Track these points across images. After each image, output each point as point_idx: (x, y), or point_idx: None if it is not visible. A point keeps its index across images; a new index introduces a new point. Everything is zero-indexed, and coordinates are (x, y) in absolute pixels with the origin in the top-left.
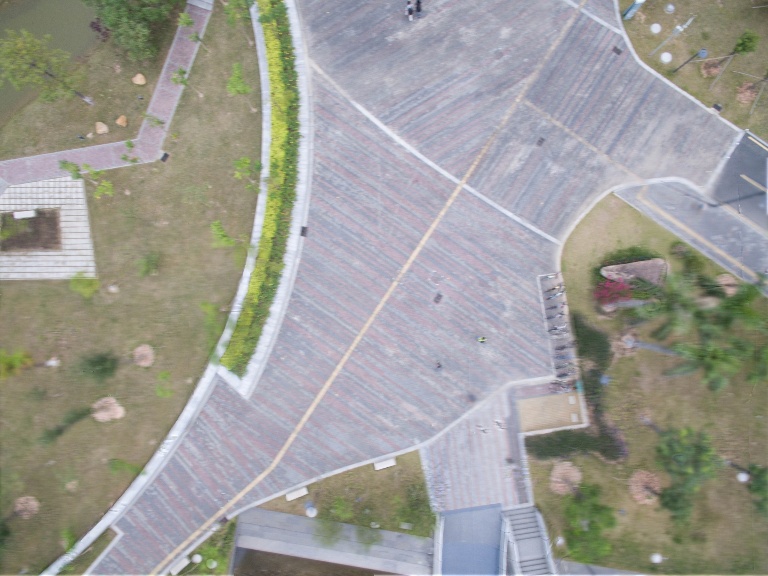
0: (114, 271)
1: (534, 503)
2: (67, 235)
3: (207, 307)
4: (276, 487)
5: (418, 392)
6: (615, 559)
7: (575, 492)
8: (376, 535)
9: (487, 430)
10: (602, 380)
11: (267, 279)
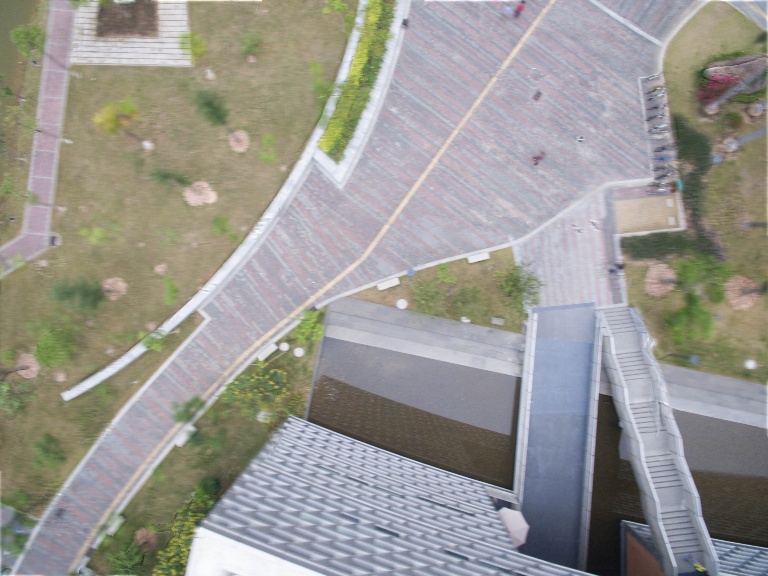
0: (211, 58)
1: (628, 304)
2: (164, 23)
3: (304, 95)
4: (367, 278)
5: (514, 189)
6: (709, 364)
7: (670, 295)
8: (467, 329)
9: (582, 230)
10: (701, 184)
11: (369, 62)
